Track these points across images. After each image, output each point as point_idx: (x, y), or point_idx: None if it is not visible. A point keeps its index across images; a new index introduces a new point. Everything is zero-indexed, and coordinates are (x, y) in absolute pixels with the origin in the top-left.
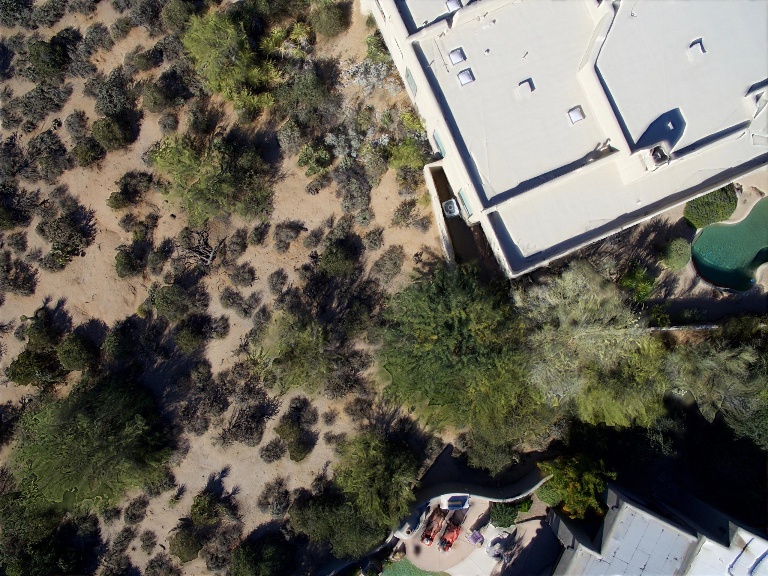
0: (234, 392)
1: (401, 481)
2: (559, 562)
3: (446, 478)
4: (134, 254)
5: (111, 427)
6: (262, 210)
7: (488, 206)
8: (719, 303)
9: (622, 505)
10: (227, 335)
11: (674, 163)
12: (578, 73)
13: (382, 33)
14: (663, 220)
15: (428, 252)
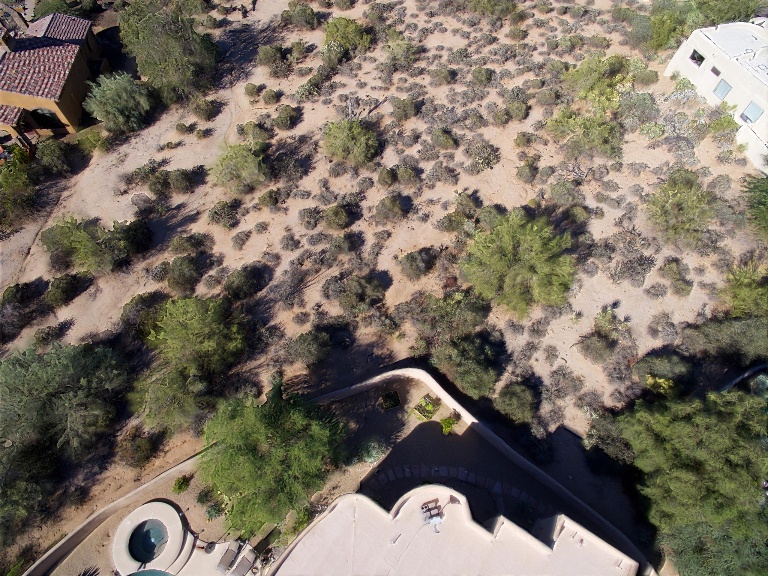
0: (616, 250)
1: None
2: None
3: None
4: None
5: None
6: (615, 156)
7: None
8: None
9: None
10: (603, 217)
11: None
12: None
13: (689, 77)
14: None
15: (750, 177)
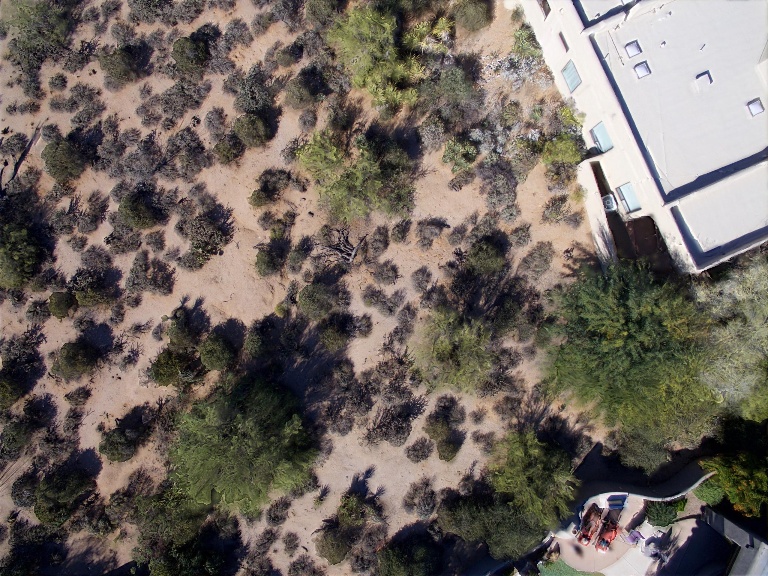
0: (378, 391)
1: (557, 480)
2: (735, 561)
3: (595, 477)
4: (275, 252)
5: (259, 428)
6: (403, 207)
7: (667, 200)
8: None
9: None
10: (370, 334)
11: None
12: (758, 65)
13: (534, 27)
14: None
15: (579, 248)
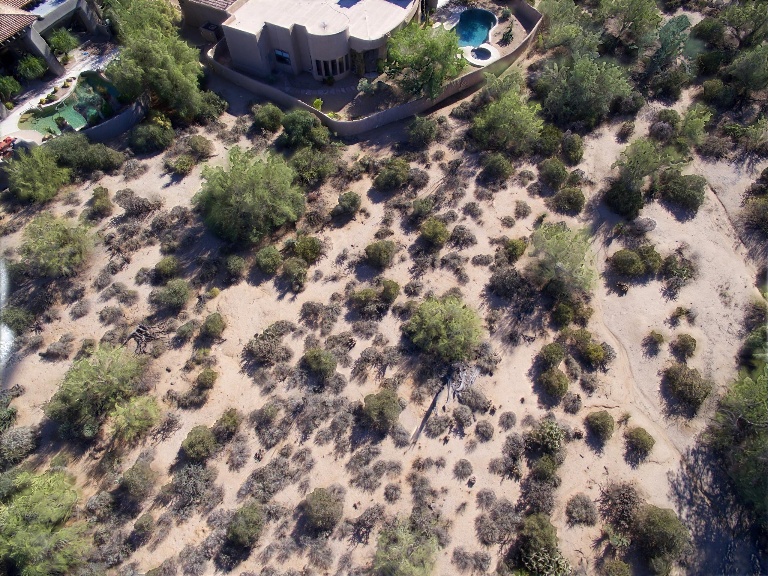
0: None
1: None
2: None
3: (2, 181)
4: (203, 332)
5: None
6: None
7: None
8: None
9: None
10: None
11: None
12: None
13: None
14: None
15: None
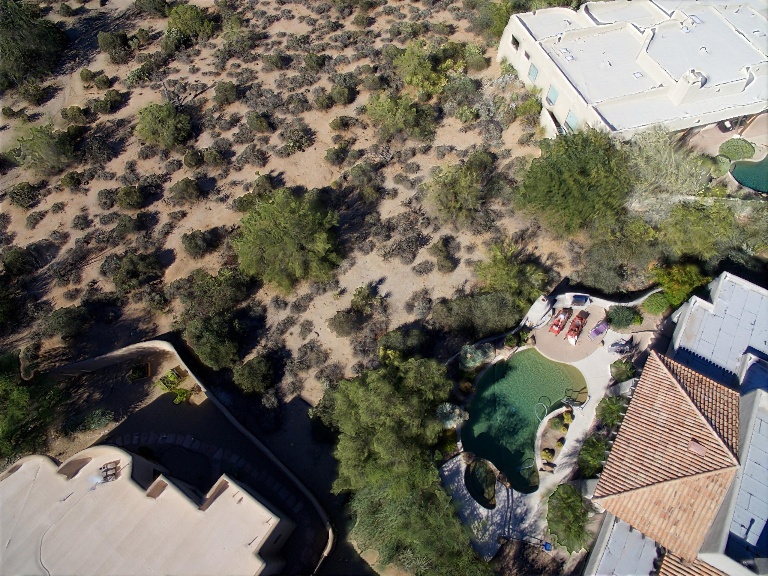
0: (397, 229)
1: (531, 283)
2: (678, 321)
3: None
4: (340, 150)
5: None
6: (427, 140)
7: None
8: (761, 198)
9: (722, 274)
10: (396, 198)
11: (705, 91)
12: (636, 60)
13: (512, 62)
14: (705, 154)
15: None
